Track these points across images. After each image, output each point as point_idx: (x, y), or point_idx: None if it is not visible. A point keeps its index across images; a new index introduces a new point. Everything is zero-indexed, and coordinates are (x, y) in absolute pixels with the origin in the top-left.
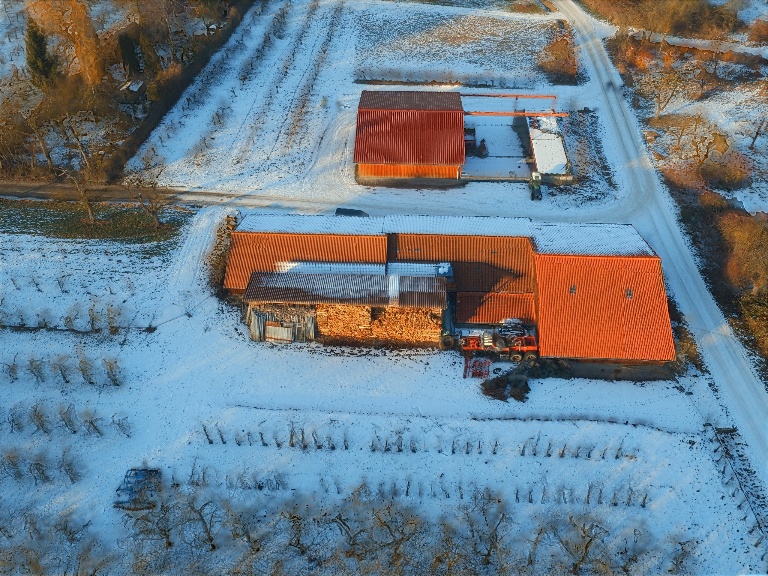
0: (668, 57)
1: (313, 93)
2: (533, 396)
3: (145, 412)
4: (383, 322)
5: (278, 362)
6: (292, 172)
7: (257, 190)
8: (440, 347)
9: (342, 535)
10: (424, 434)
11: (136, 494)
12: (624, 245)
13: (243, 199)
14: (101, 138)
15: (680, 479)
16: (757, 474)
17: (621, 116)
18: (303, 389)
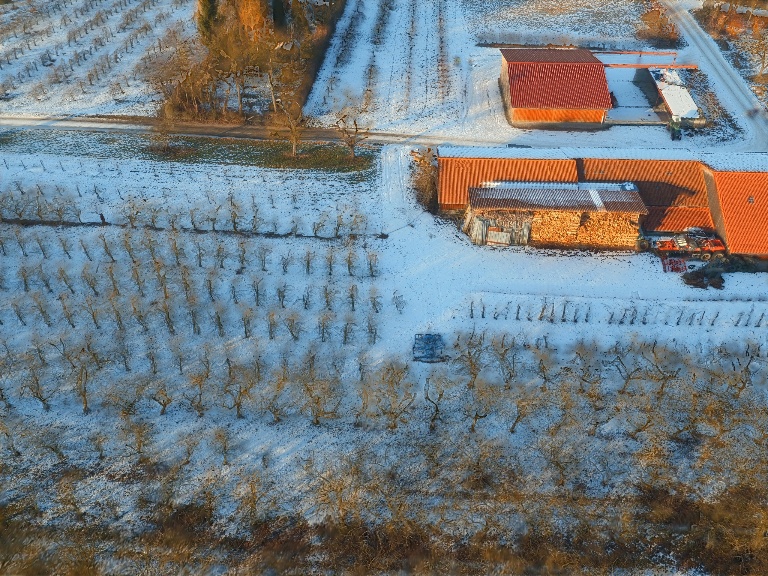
0: (757, 25)
1: (443, 54)
2: (728, 285)
3: (406, 296)
4: (588, 228)
5: (503, 260)
6: (451, 118)
7: (427, 132)
8: (636, 250)
9: (621, 373)
10: (649, 311)
11: (431, 350)
12: None
13: (417, 139)
14: (270, 90)
15: None
16: None
17: (726, 74)
18: (532, 280)
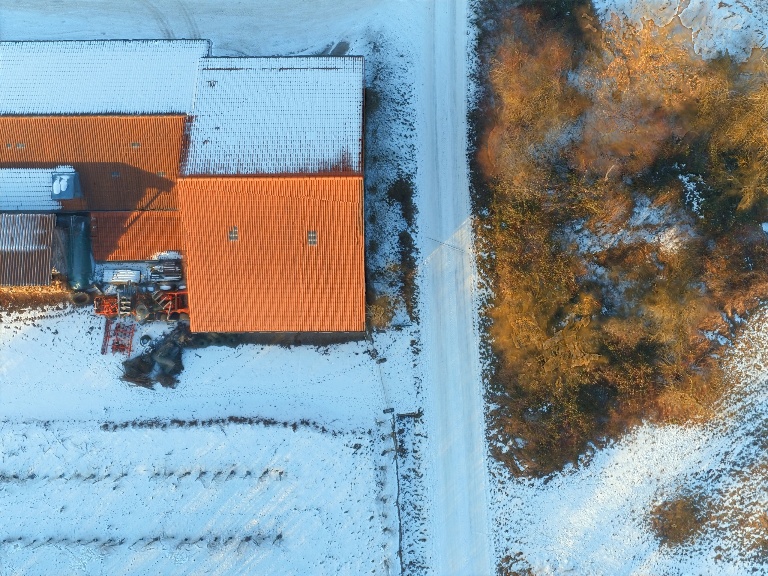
0: None
1: None
2: (186, 378)
3: None
4: None
5: None
6: None
7: None
8: (73, 303)
9: None
10: (42, 455)
11: None
12: (325, 133)
13: None
14: None
15: (330, 498)
16: (423, 479)
17: None
18: None
